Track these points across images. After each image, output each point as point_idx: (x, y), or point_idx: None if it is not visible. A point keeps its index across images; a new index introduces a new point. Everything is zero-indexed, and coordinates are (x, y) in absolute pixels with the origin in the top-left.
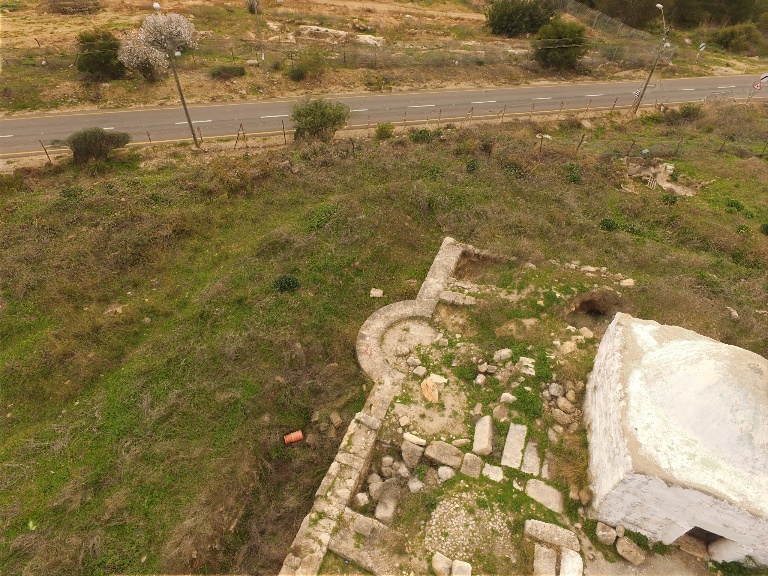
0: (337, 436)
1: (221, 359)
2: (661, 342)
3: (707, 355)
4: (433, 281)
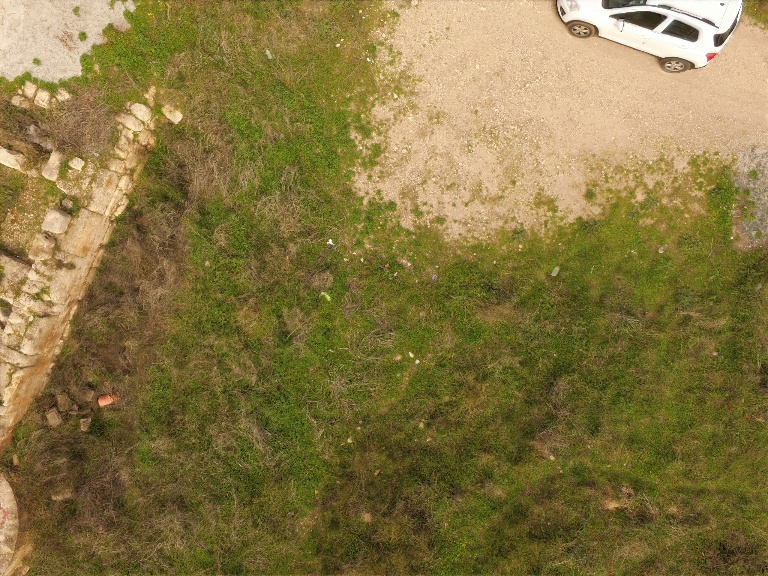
0: (53, 395)
1: (191, 505)
2: None
3: None
4: None
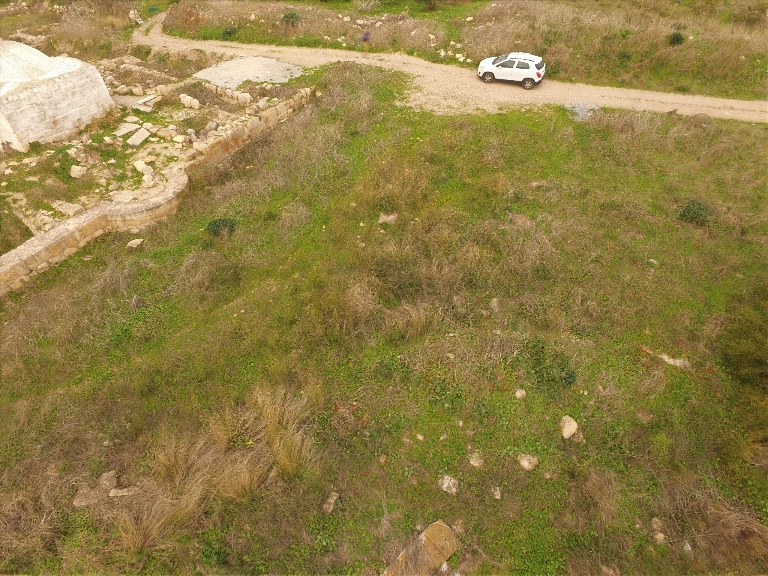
0: None
1: None
2: (4, 82)
3: (7, 53)
4: (71, 226)
